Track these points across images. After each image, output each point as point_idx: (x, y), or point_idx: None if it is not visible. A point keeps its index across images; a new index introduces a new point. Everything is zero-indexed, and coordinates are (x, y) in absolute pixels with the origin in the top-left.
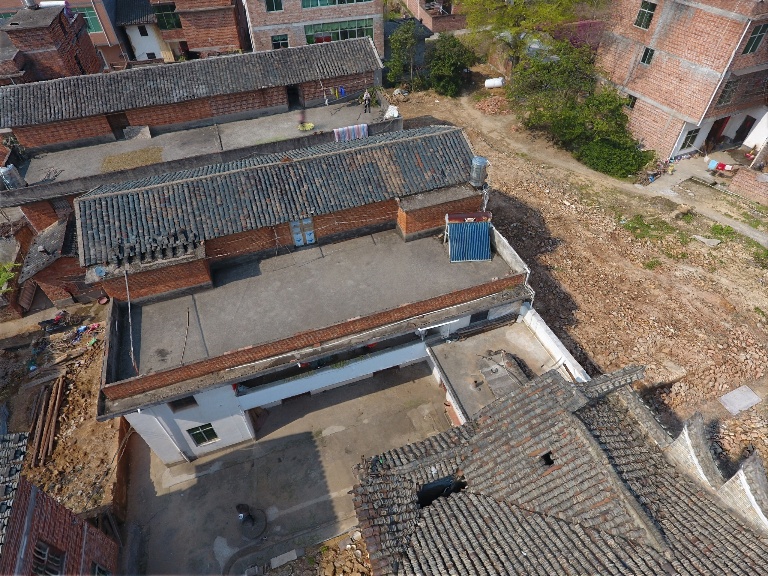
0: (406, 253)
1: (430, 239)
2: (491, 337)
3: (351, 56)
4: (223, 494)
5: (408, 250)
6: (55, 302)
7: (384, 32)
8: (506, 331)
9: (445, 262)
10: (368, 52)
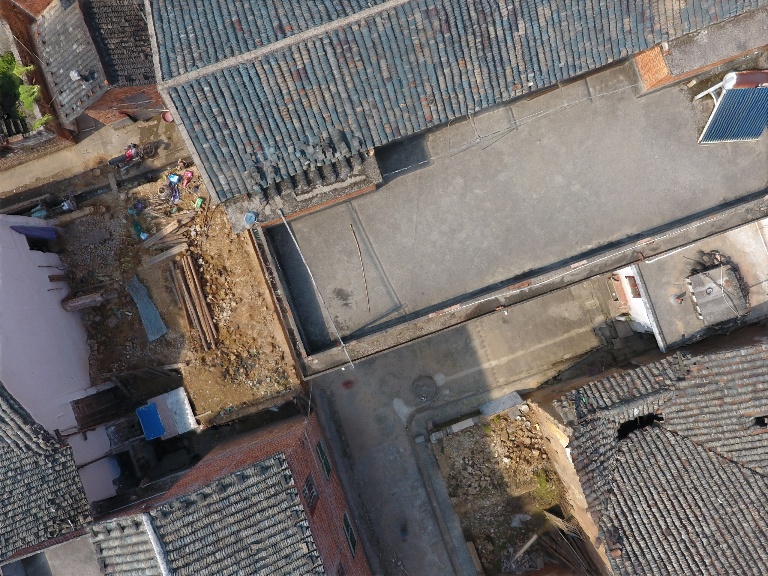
0: (637, 122)
1: (674, 91)
2: None
3: None
4: (391, 362)
5: (640, 115)
6: (110, 124)
7: None
8: None
9: (691, 141)
10: None
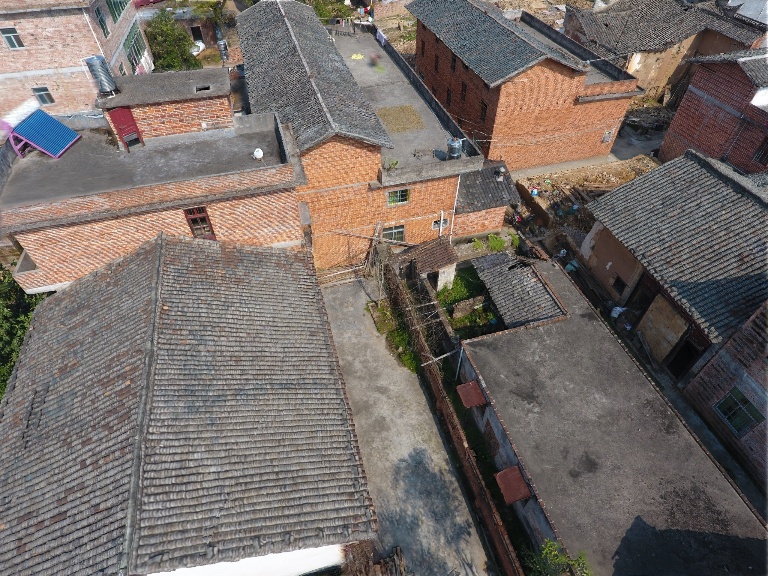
0: None
1: None
2: None
3: (297, 7)
4: None
5: None
6: None
7: (144, 32)
8: None
9: None
10: (293, 2)
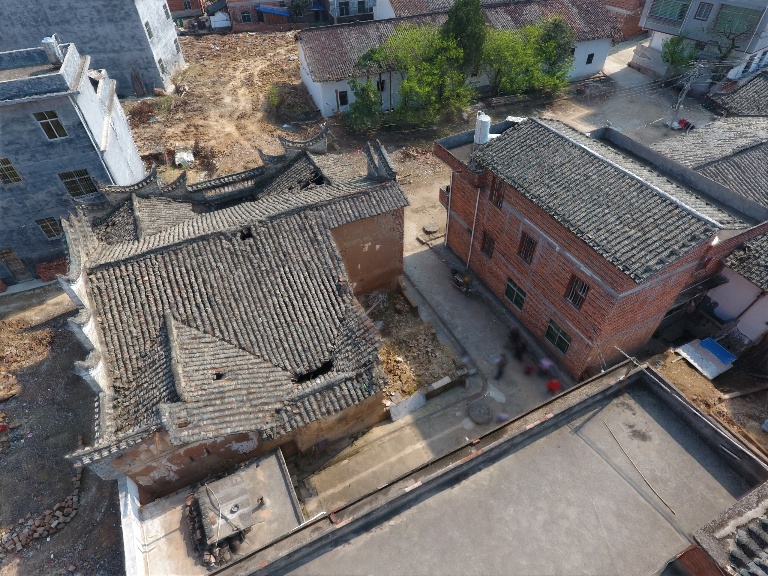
0: None
1: None
2: None
3: None
4: None
5: None
6: None
7: None
8: None
9: None
10: None
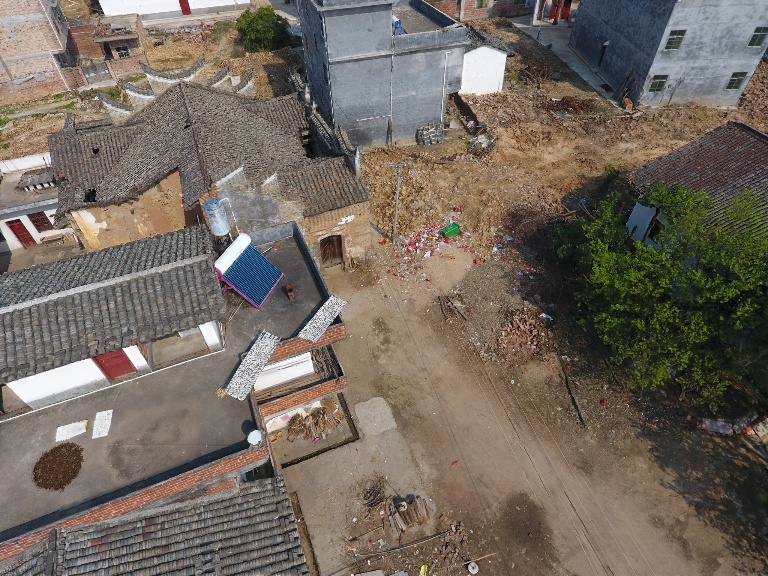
0: None
1: None
2: (5, 188)
3: None
4: None
5: None
6: None
7: None
8: (6, 181)
9: None
10: None
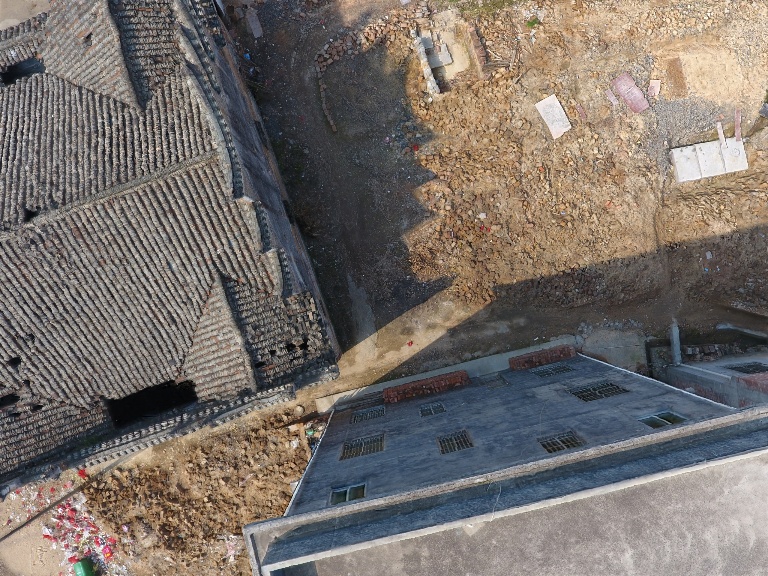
0: None
1: None
2: None
3: None
4: None
5: None
6: None
7: None
8: None
9: None
10: None
